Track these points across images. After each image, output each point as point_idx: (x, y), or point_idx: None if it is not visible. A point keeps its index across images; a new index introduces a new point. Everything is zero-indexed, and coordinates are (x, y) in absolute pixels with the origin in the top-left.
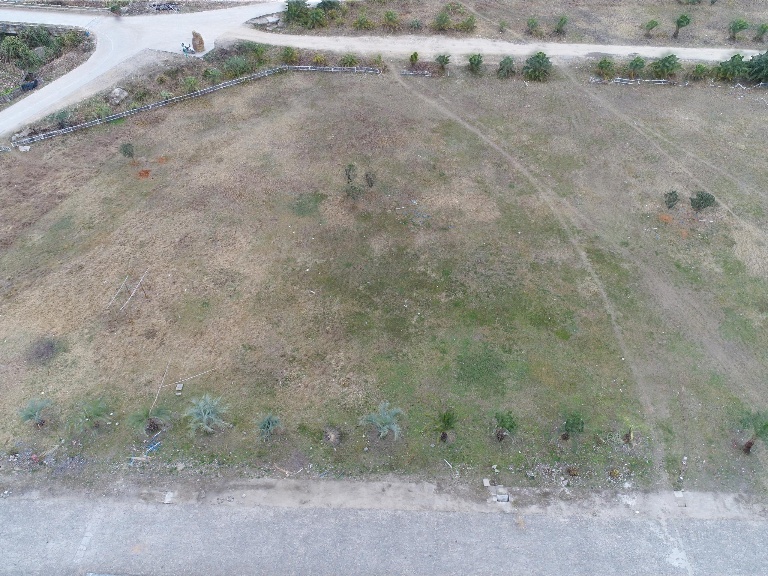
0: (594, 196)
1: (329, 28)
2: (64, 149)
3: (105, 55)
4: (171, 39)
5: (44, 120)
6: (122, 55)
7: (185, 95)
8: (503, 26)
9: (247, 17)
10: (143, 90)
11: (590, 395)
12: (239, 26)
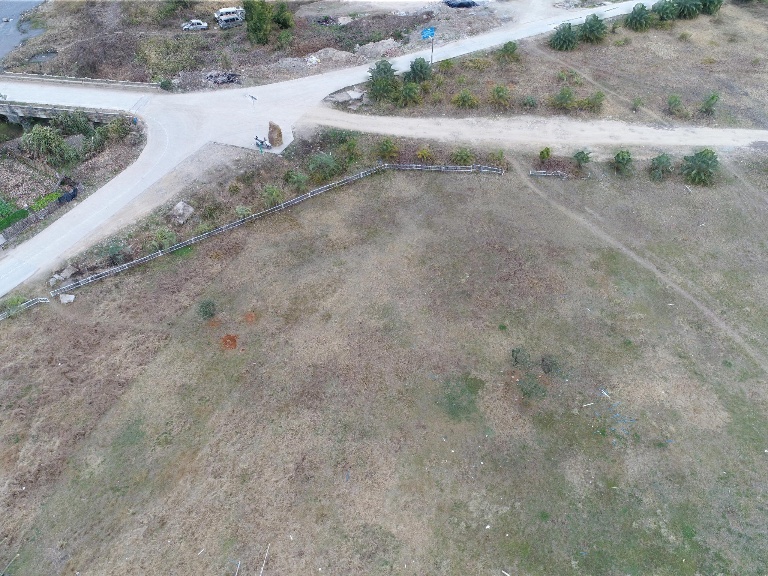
0: None
1: (424, 106)
2: (119, 299)
3: (159, 151)
4: (239, 127)
5: (90, 253)
6: (181, 151)
7: (266, 210)
8: (638, 104)
9: (324, 92)
10: (212, 204)
11: None
12: (317, 105)
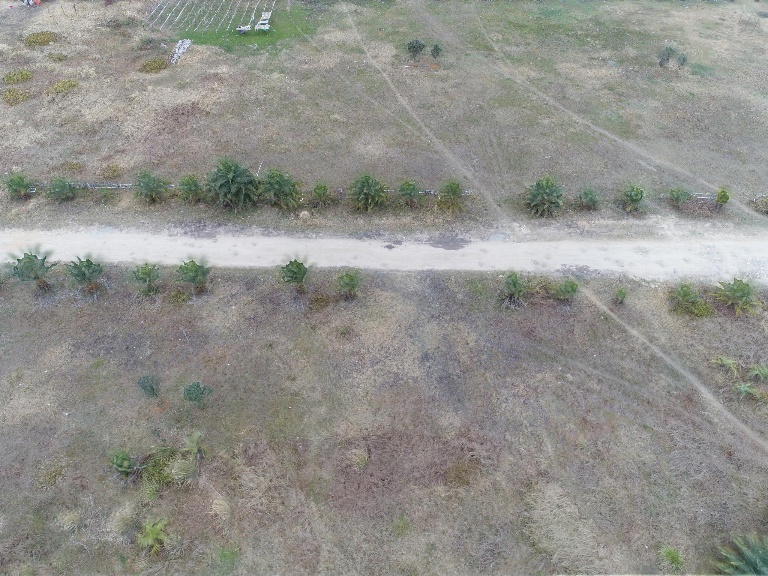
0: (484, 78)
1: None
2: None
3: None
4: None
5: None
6: None
7: None
8: None
9: None
10: None
11: (499, 8)
12: None
